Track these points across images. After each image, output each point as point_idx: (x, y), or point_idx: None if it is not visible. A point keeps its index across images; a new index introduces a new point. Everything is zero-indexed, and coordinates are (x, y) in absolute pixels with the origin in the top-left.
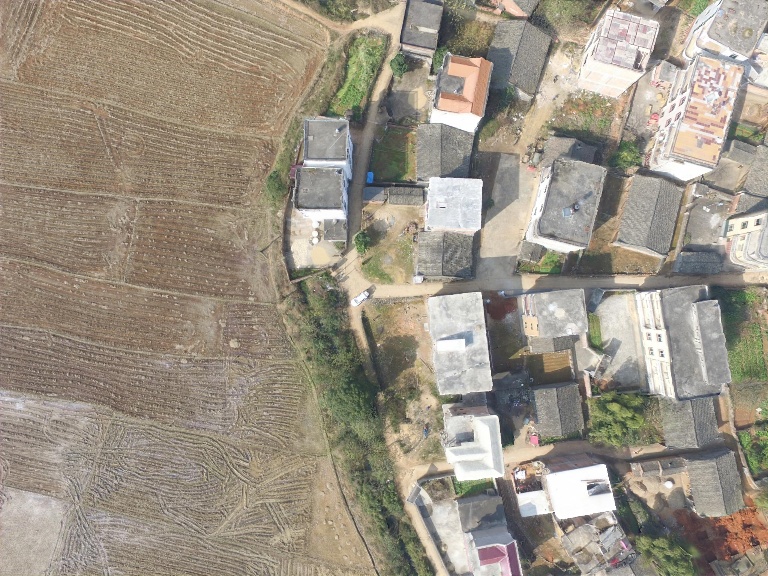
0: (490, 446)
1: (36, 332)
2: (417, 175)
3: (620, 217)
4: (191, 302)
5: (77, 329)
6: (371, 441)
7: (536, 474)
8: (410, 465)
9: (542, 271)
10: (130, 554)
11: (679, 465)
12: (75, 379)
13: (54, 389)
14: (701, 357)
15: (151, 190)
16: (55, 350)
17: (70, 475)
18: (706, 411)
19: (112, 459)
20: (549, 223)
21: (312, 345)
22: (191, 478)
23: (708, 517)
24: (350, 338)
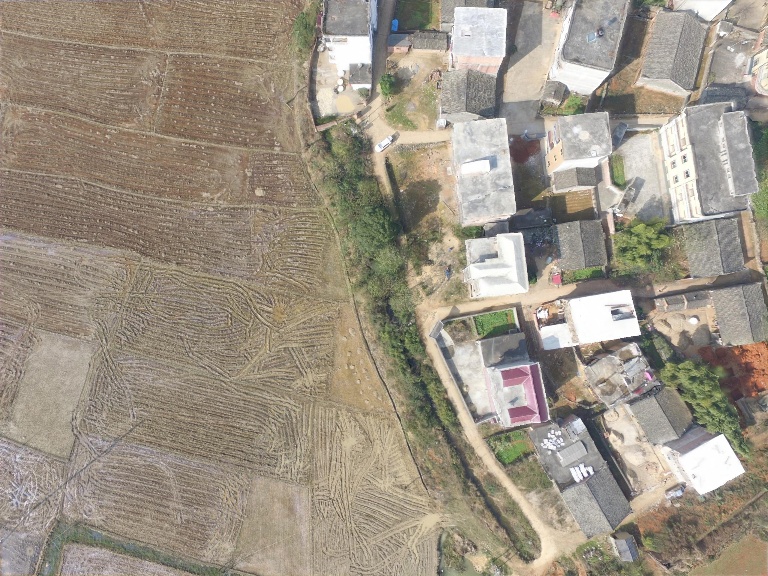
0: (514, 260)
1: (69, 180)
2: (441, 18)
3: (643, 55)
4: (218, 152)
5: (108, 177)
6: (394, 281)
7: (559, 312)
8: (432, 308)
9: (565, 114)
10: (155, 396)
11: (704, 297)
12: (105, 225)
13: (85, 235)
14: (727, 168)
15: (181, 44)
16: (86, 197)
17: (98, 318)
18: (732, 242)
19: (139, 303)
20: (573, 49)
21: (336, 190)
22: (216, 322)
23: (734, 353)
24: (374, 182)
